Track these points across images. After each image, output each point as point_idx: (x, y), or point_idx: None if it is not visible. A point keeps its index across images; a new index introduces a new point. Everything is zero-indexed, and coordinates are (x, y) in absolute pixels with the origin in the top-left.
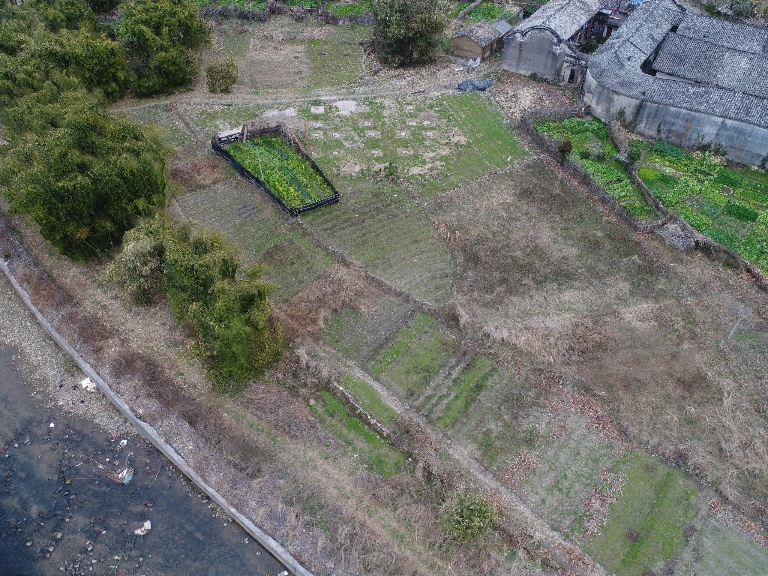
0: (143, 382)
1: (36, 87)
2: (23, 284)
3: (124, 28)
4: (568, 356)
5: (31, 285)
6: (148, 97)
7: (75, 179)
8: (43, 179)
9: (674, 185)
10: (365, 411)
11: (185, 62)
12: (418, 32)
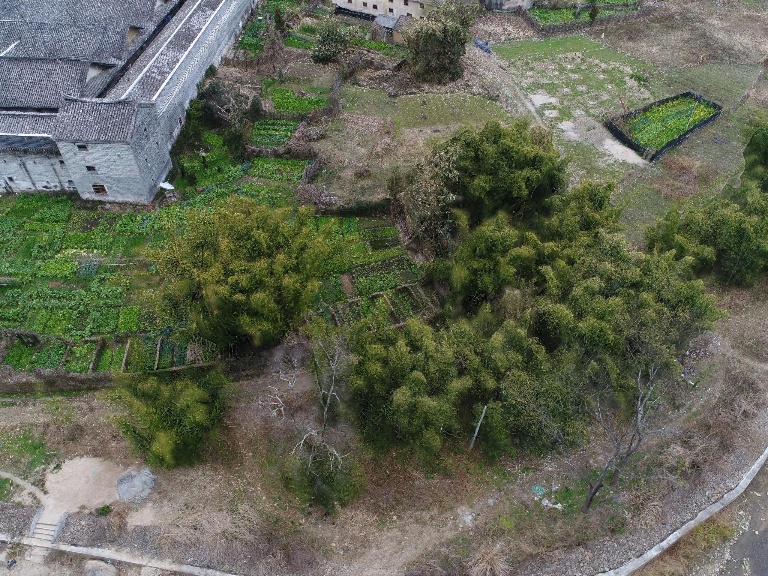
0: None
1: None
2: None
3: None
4: None
5: None
6: None
7: None
8: None
9: (597, 1)
10: None
11: None
12: None
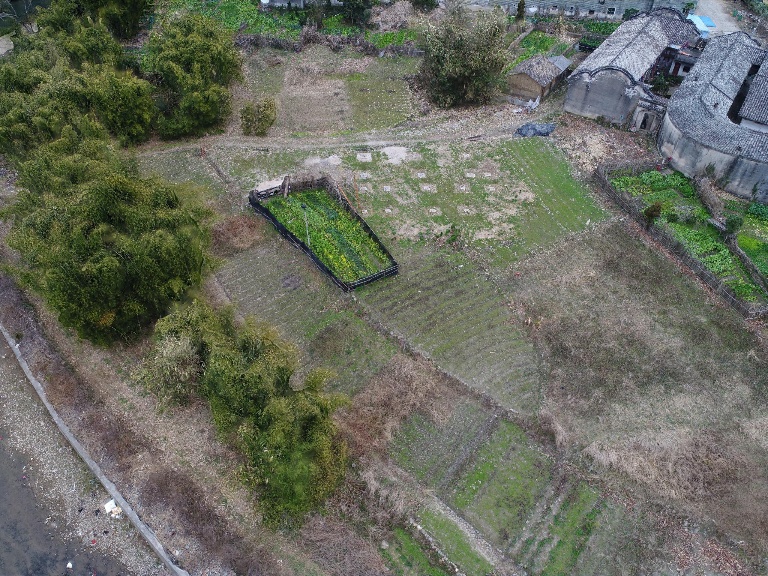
0: (180, 516)
1: (54, 130)
2: (37, 374)
3: (151, 63)
4: (692, 489)
5: (46, 377)
6: (176, 139)
7: (101, 259)
8: (64, 262)
9: None
10: (451, 561)
11: (218, 102)
12: (475, 71)
